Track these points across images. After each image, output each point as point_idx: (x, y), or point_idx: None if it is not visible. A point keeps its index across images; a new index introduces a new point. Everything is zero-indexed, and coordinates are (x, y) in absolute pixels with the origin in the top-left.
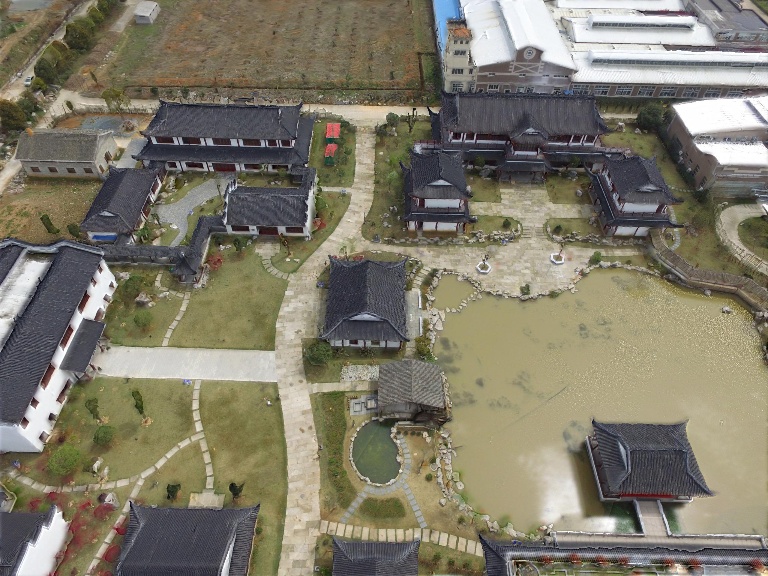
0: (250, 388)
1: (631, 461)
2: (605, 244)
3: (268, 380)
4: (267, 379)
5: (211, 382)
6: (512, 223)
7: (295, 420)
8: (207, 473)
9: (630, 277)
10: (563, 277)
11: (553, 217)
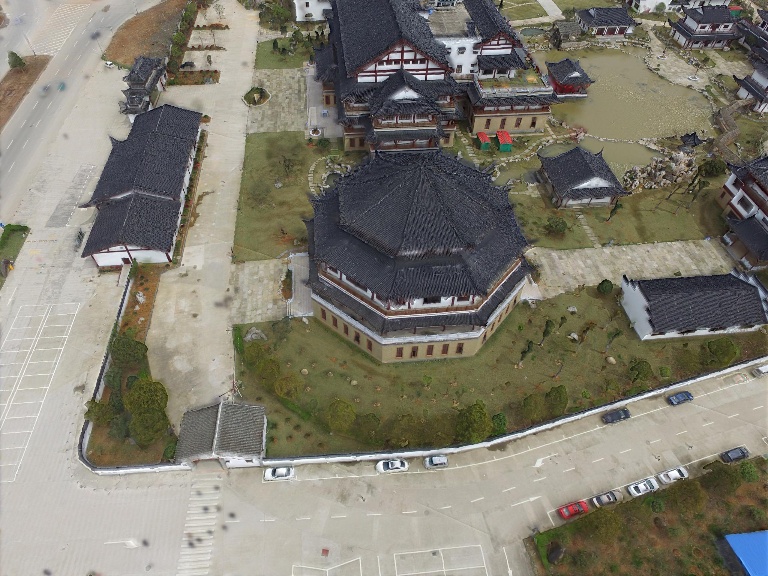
0: (543, 11)
1: (563, 61)
2: (725, 94)
3: (549, 14)
4: (549, 14)
5: (540, 5)
6: (711, 64)
7: (535, 20)
8: (504, 8)
9: (703, 102)
10: (679, 80)
11: (732, 77)
